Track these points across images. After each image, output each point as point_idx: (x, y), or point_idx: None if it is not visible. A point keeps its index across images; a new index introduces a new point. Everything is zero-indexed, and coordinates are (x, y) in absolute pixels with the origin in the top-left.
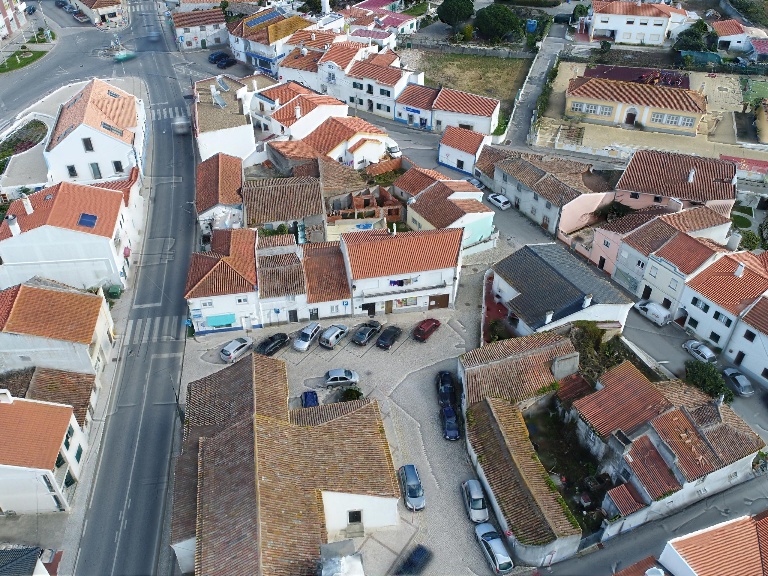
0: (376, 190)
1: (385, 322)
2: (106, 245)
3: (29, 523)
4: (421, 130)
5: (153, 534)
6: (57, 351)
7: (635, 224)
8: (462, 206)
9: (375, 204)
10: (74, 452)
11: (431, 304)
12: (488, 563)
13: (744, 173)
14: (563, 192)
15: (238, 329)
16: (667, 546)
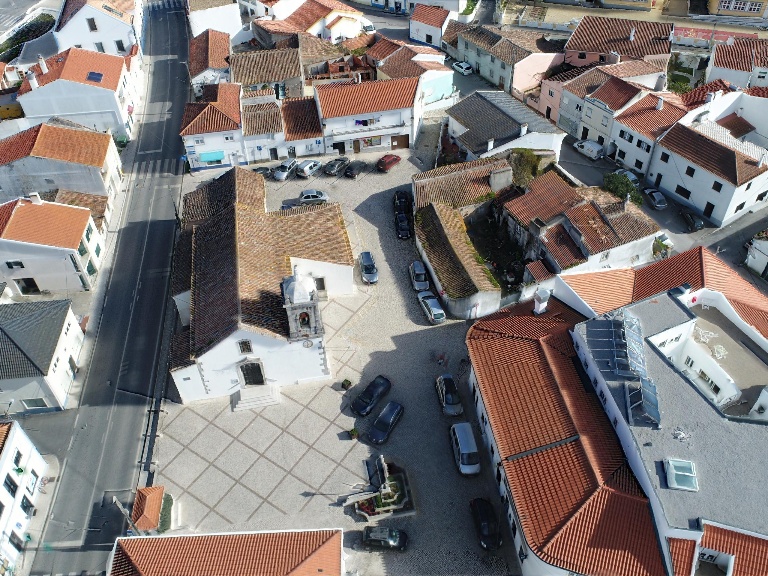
0: (350, 59)
1: (353, 159)
2: (112, 97)
3: (61, 299)
4: (396, 13)
5: (160, 304)
6: (75, 174)
7: (576, 75)
8: (424, 66)
9: (348, 69)
10: (94, 247)
11: (394, 144)
12: (426, 317)
13: (691, 40)
14: (514, 50)
15: (227, 166)
16: (556, 278)
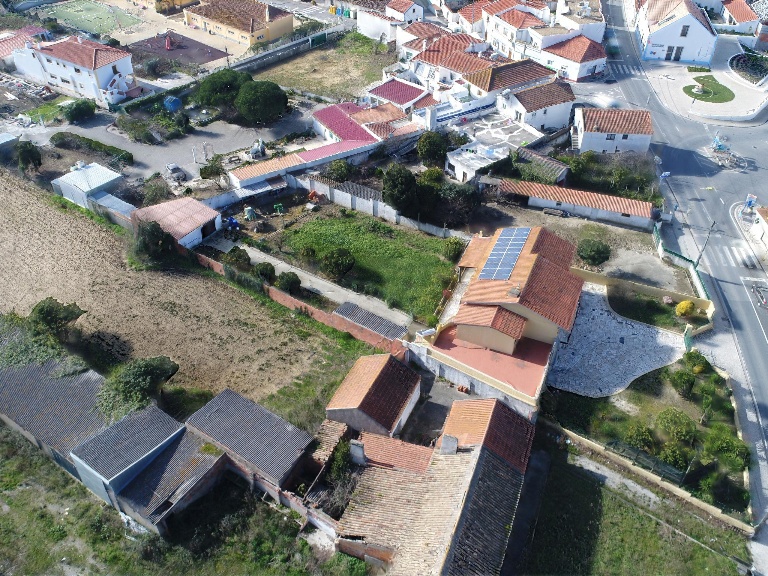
0: None
1: None
2: None
3: None
4: None
5: None
6: None
7: None
8: None
9: None
10: None
11: None
12: None
13: None
14: None
15: None
16: None
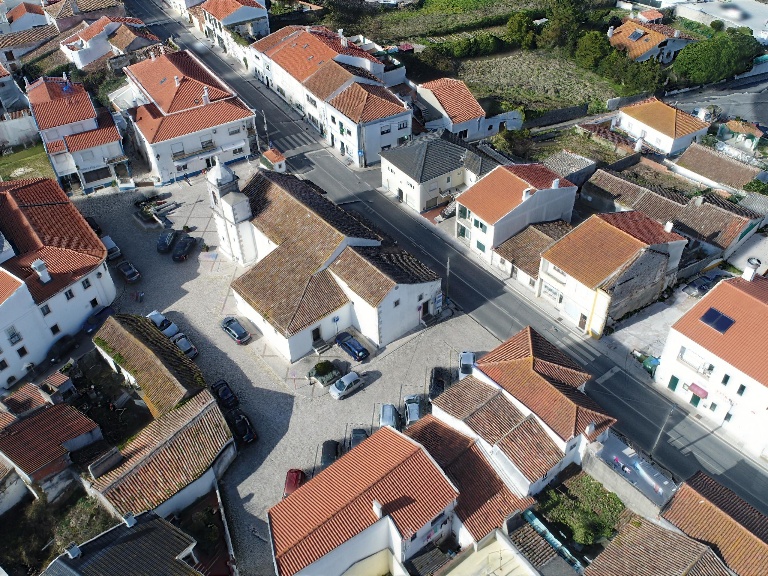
0: None
1: None
2: None
3: None
4: None
5: None
6: None
7: None
8: None
9: None
10: None
11: None
12: None
13: None
14: None
15: None
16: None
